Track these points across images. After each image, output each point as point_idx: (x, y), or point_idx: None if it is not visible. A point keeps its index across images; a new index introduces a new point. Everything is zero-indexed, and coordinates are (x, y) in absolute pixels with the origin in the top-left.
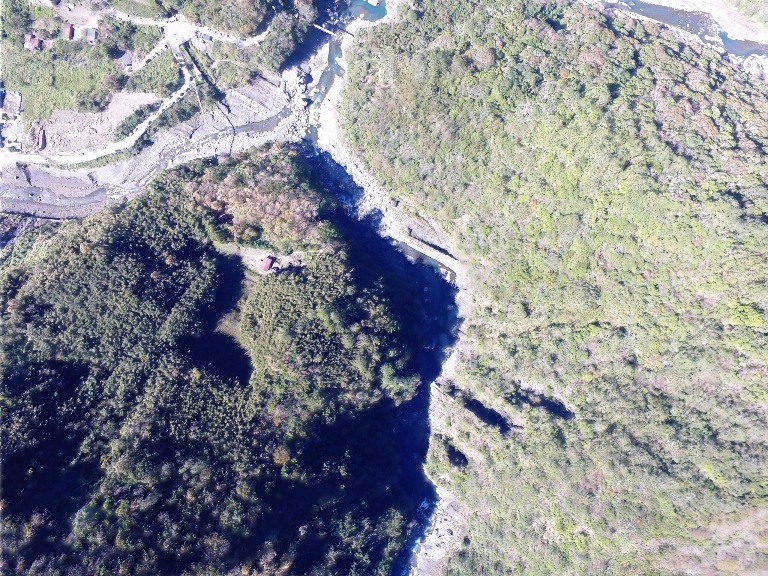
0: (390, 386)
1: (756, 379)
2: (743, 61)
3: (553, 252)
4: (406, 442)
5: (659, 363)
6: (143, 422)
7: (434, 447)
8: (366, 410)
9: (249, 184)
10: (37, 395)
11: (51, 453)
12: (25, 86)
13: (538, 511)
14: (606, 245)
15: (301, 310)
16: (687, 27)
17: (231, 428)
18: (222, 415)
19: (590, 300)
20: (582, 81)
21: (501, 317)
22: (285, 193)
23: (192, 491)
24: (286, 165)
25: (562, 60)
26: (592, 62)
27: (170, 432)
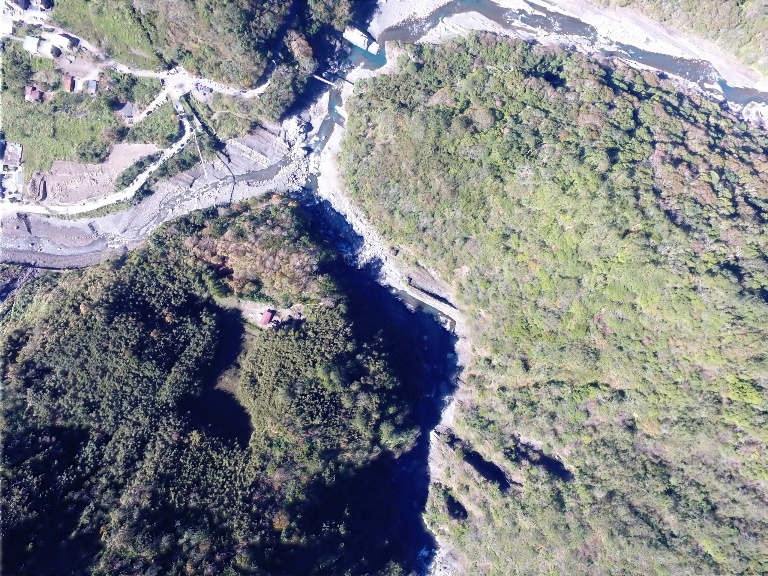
0: (390, 442)
1: (755, 457)
2: (742, 109)
3: (552, 312)
4: (406, 490)
5: (658, 431)
6: (143, 490)
7: (433, 497)
8: (366, 465)
9: (249, 238)
10: (37, 464)
11: (51, 524)
12: (26, 137)
13: (537, 568)
14: (605, 310)
15: (301, 368)
16: (686, 75)
17: (231, 493)
18: (222, 479)
19: (589, 364)
20: (581, 144)
21: (500, 371)
22: (285, 247)
23: (192, 562)
24: (286, 218)
25: (561, 121)
26: (591, 124)
27: (170, 500)
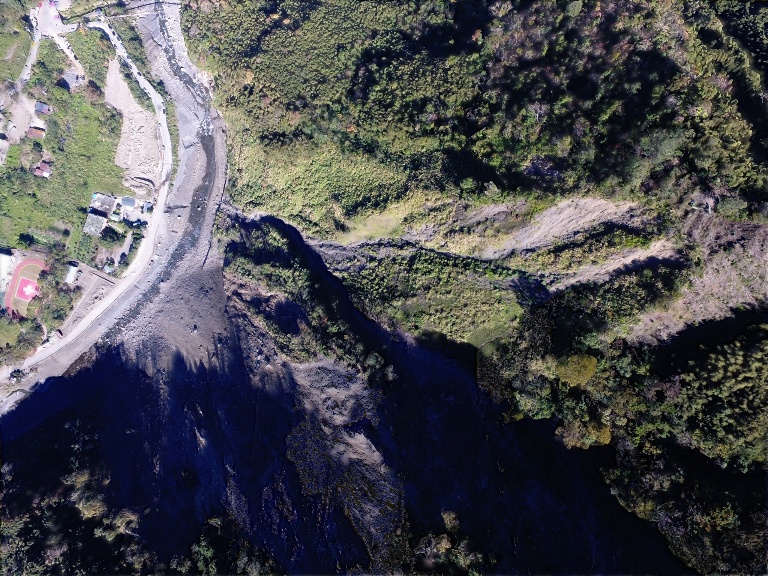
0: None
1: None
2: None
3: None
4: None
5: None
6: None
7: None
8: None
9: None
10: None
11: None
12: (87, 187)
13: None
14: None
15: None
16: None
17: None
18: None
19: None
20: None
21: None
22: None
23: None
24: None
25: None
26: None
27: None
